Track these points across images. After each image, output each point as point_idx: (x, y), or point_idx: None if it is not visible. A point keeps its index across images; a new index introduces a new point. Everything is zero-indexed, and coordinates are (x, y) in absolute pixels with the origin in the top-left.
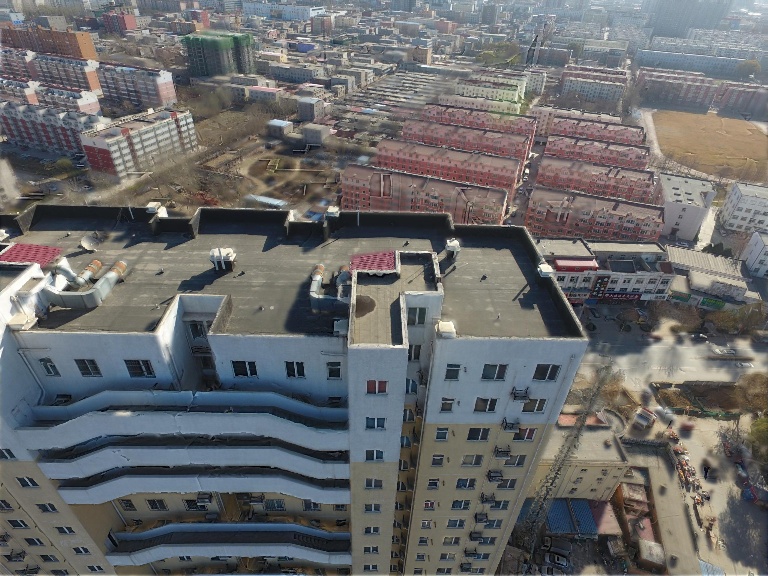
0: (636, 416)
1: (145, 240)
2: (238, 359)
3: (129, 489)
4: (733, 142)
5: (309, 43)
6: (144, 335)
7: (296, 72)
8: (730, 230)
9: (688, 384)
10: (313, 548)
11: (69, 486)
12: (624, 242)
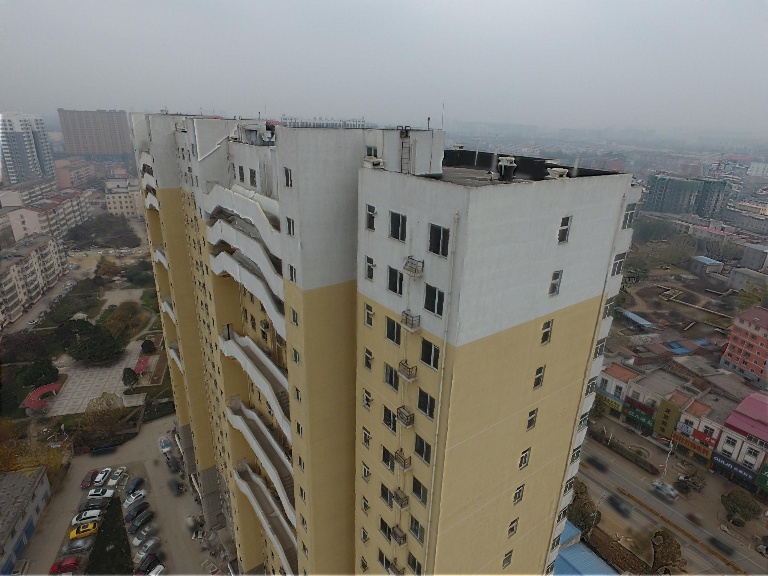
0: None
1: None
2: None
3: (223, 265)
4: None
5: None
6: (255, 147)
7: None
8: None
9: None
10: (279, 402)
11: None
12: None
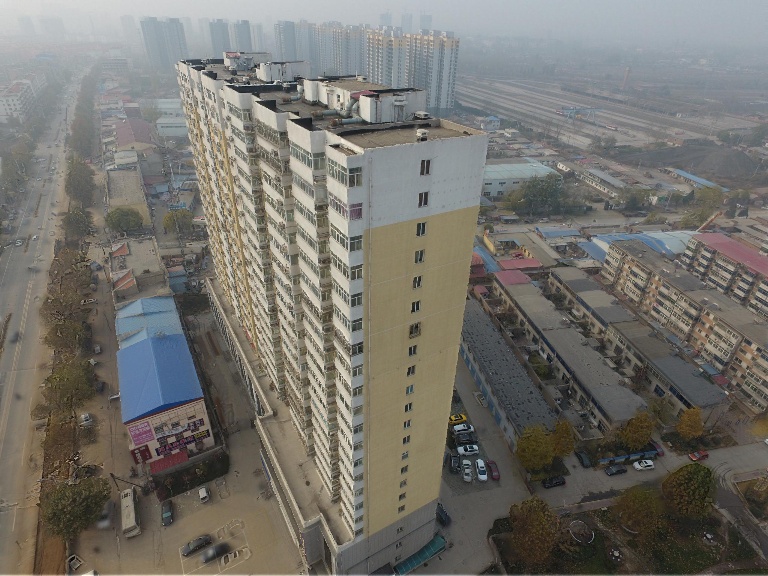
0: (92, 265)
1: None
2: None
3: None
4: None
5: None
6: None
7: None
8: None
9: None
10: None
11: None
12: None
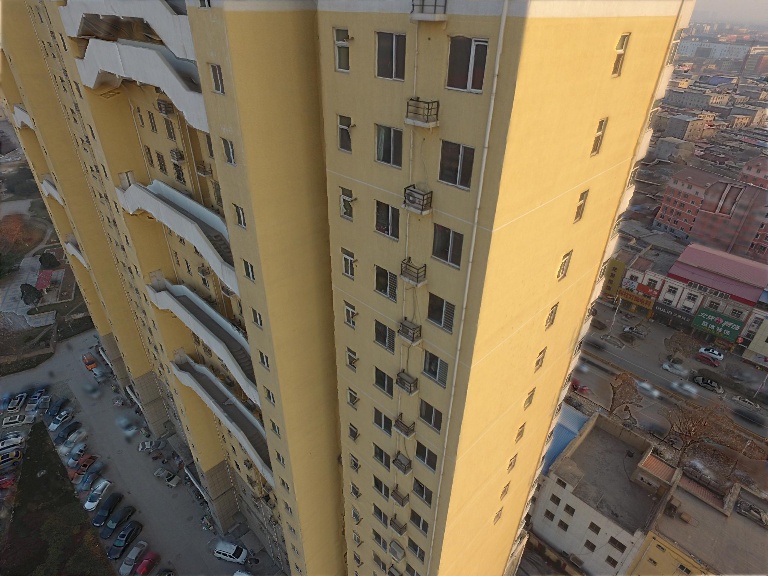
0: None
1: None
2: None
3: (96, 62)
4: None
5: (727, 76)
6: None
7: (690, 97)
8: None
9: None
10: (213, 245)
11: None
12: None
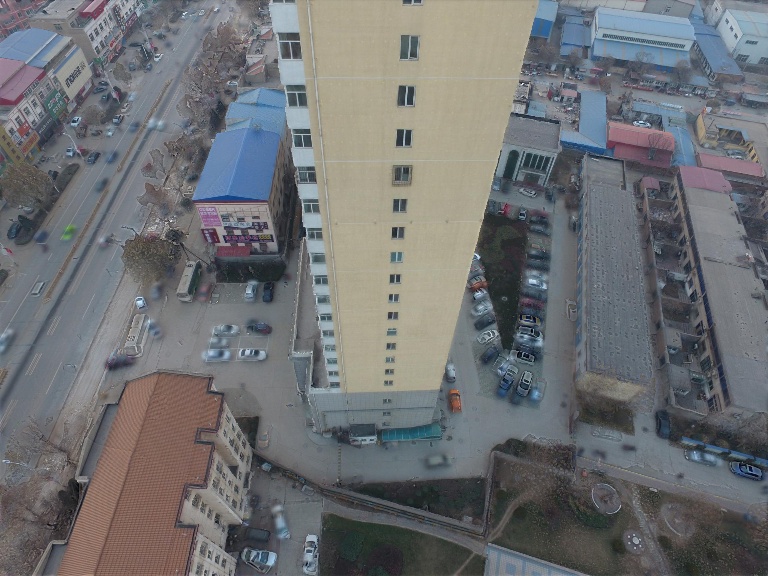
0: None
1: None
2: None
3: None
4: None
5: None
6: None
7: None
8: None
9: None
10: None
11: None
12: None
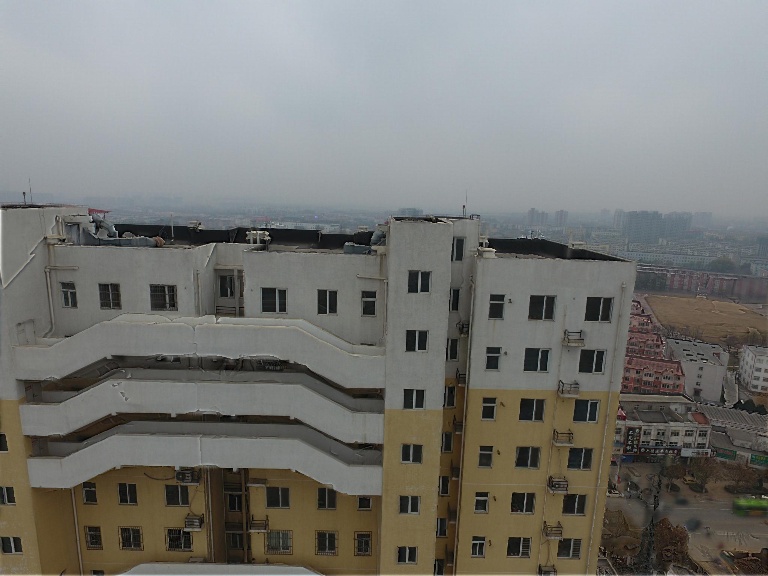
0: None
1: (182, 244)
2: (269, 284)
3: (114, 458)
4: (730, 319)
5: None
6: (179, 250)
7: None
8: (756, 392)
9: (767, 553)
10: None
11: (42, 456)
12: (647, 393)
